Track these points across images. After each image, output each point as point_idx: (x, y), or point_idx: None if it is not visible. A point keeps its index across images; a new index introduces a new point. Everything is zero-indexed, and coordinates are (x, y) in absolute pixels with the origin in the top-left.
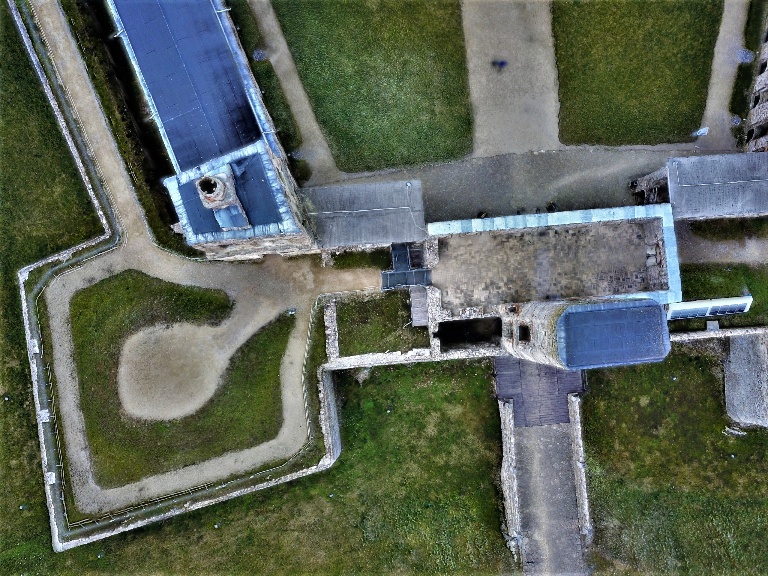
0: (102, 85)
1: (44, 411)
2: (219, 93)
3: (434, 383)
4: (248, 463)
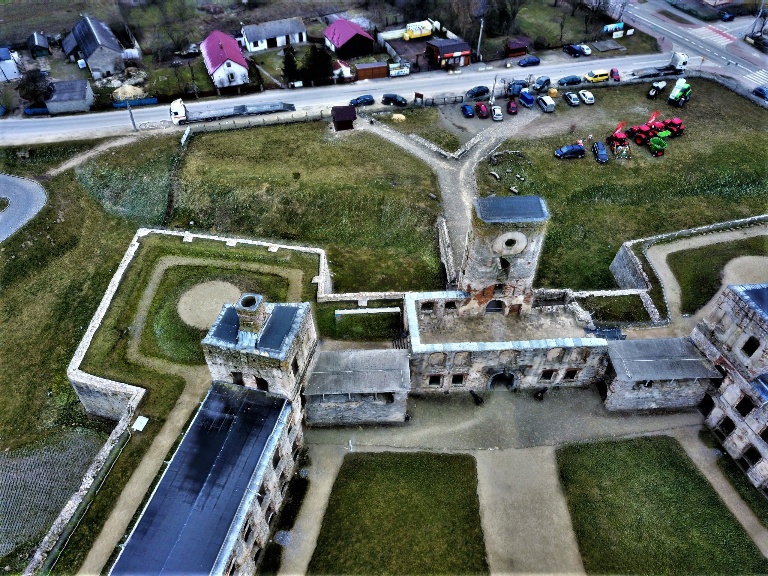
0: None
1: None
2: None
3: None
4: (681, 243)
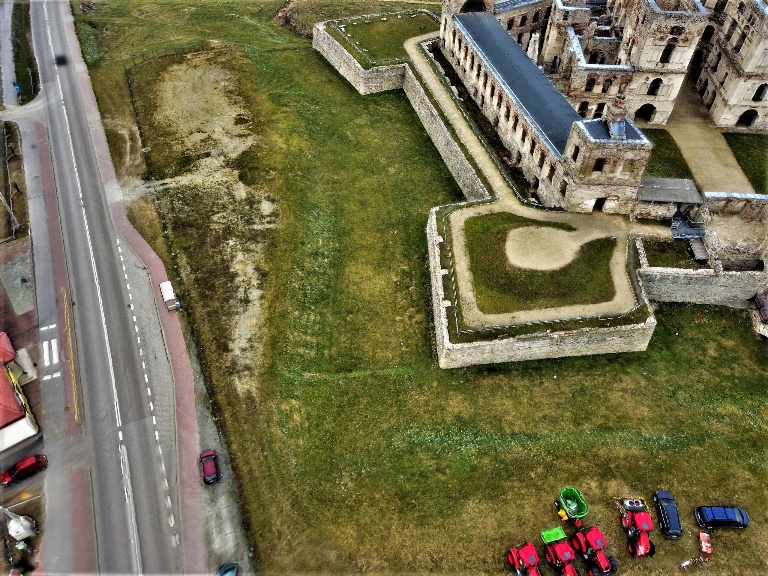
0: None
1: (444, 269)
2: None
3: (709, 320)
4: (593, 312)
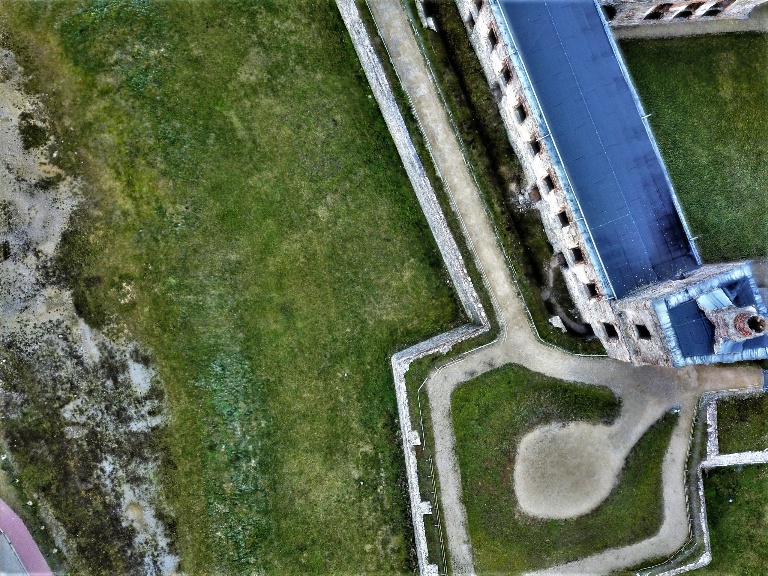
0: (480, 177)
1: (426, 503)
2: (647, 200)
3: None
4: (630, 560)
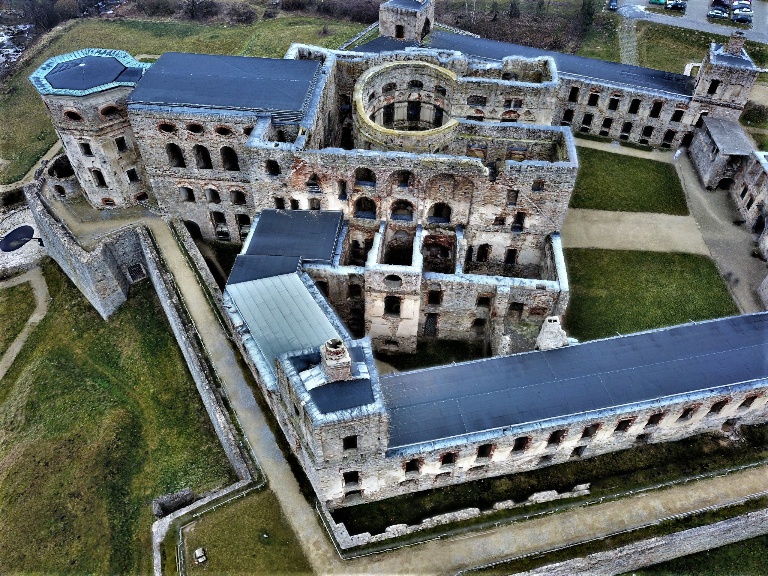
0: (735, 465)
1: None
2: None
3: None
4: None
